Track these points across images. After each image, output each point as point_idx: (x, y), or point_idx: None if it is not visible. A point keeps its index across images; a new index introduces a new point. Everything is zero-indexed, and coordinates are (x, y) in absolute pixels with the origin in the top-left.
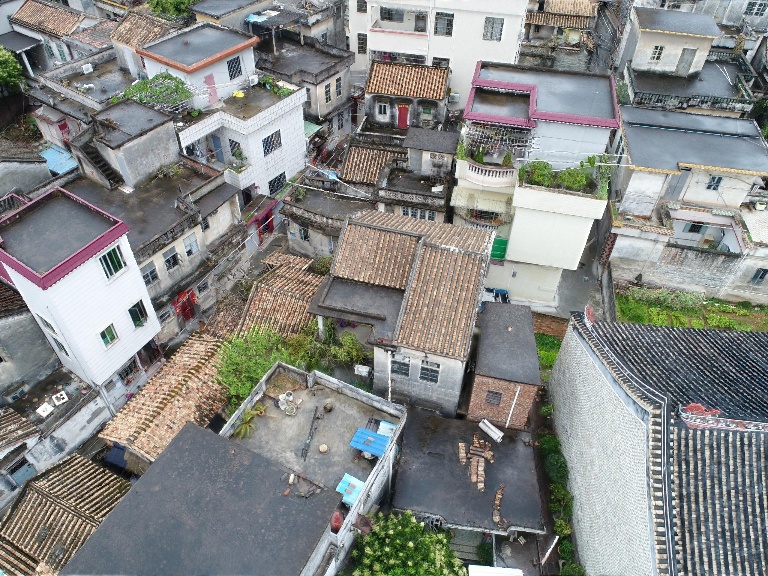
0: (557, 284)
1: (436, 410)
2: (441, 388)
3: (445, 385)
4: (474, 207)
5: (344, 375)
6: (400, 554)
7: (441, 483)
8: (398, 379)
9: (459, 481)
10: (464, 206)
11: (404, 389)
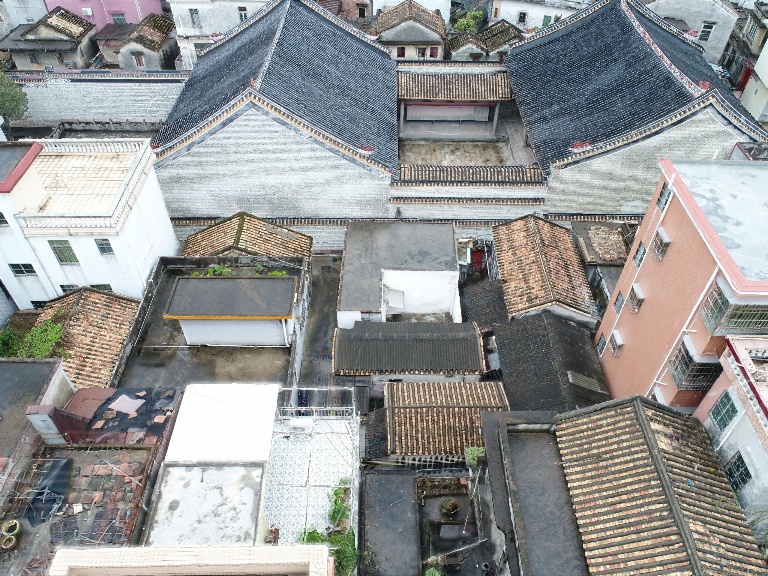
0: (766, 111)
1: None
2: None
3: None
4: (767, 25)
5: None
6: None
7: None
8: None
9: None
10: (765, 23)
11: None
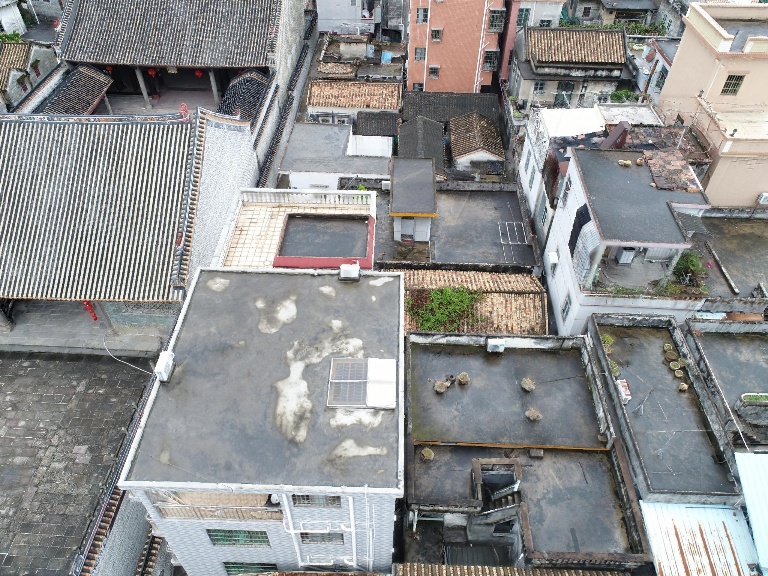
0: None
1: (56, 20)
2: (53, 5)
3: (53, 2)
4: None
5: (21, 12)
6: (3, 37)
7: (42, 34)
8: (36, 4)
9: (50, 34)
10: None
11: (41, 11)
